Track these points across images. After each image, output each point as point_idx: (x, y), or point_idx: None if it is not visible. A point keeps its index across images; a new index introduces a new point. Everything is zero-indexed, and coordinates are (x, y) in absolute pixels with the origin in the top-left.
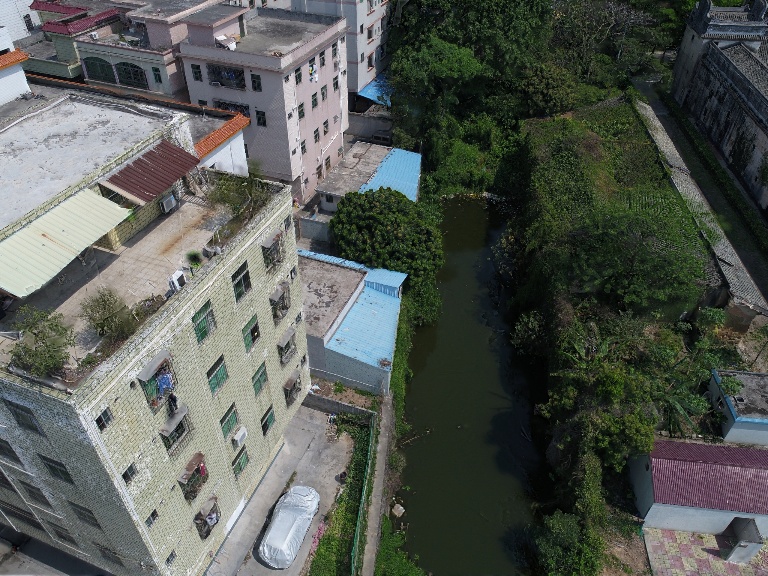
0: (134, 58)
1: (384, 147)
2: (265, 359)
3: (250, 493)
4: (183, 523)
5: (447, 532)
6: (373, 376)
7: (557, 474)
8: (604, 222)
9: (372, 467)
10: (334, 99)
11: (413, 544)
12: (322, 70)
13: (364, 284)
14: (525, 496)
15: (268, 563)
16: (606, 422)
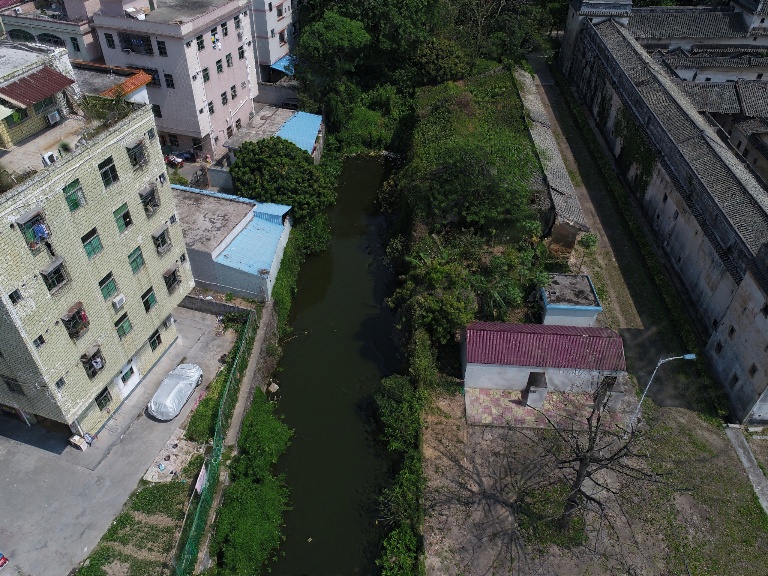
0: (54, 29)
1: (289, 111)
2: (140, 244)
3: (145, 371)
4: (70, 358)
5: (314, 403)
6: (255, 284)
7: (401, 352)
8: (445, 154)
9: (248, 349)
10: (240, 67)
11: (284, 412)
12: (225, 39)
13: (253, 215)
14: (379, 374)
15: (155, 416)
16: (428, 301)
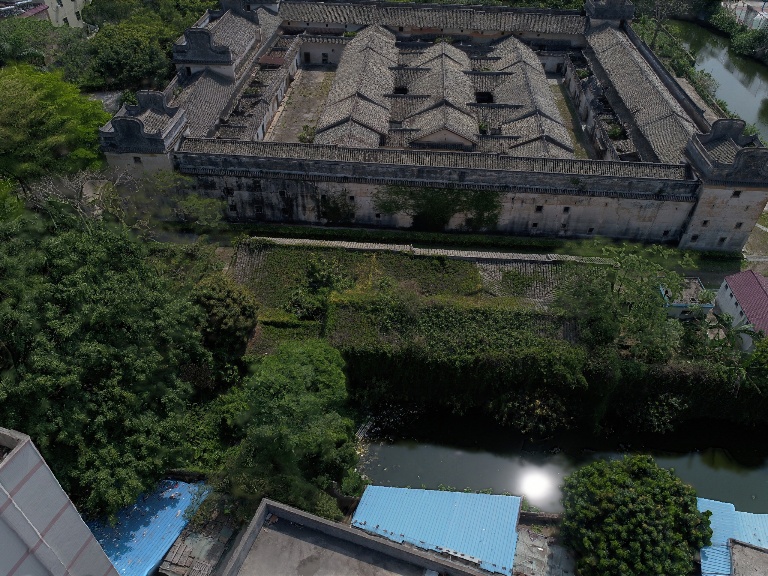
0: None
1: None
2: None
3: None
4: None
5: None
6: None
7: None
8: None
9: None
10: None
11: None
12: None
13: None
14: None
15: None
16: None
